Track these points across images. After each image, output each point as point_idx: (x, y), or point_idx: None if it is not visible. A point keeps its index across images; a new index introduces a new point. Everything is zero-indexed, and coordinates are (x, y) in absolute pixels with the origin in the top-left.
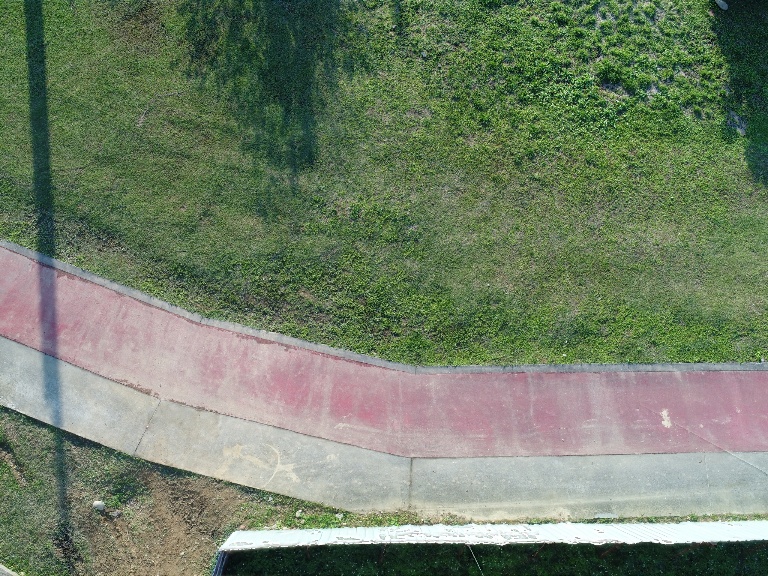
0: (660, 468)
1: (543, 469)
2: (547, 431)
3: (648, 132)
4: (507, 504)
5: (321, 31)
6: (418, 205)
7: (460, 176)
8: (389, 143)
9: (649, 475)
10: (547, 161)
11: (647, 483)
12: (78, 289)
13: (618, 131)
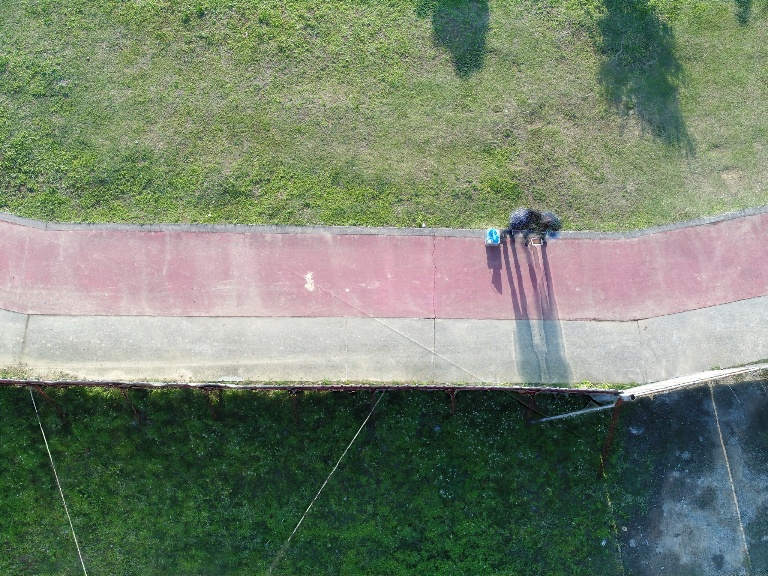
0: (296, 332)
1: (169, 329)
2: (179, 291)
3: None
4: (125, 364)
5: None
6: (72, 60)
7: (121, 32)
8: None
9: (283, 338)
10: (217, 19)
11: (280, 347)
12: None
13: None
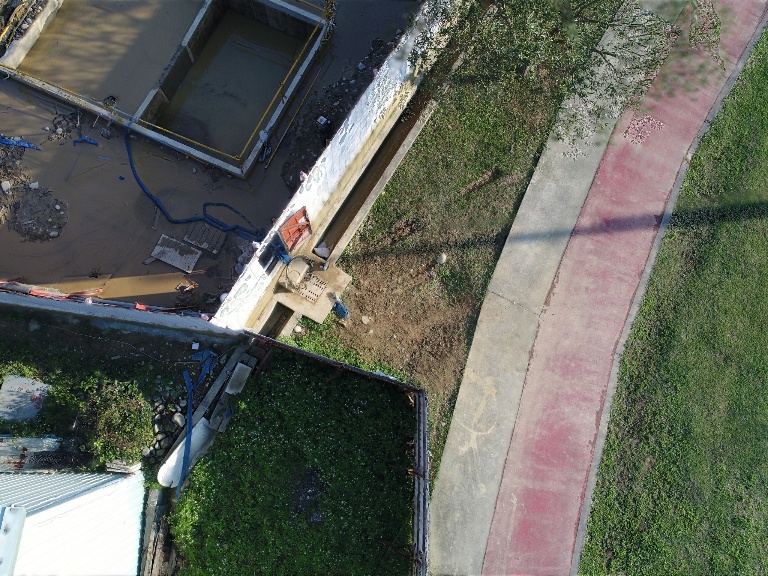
0: None
1: None
2: None
3: None
4: None
5: None
6: None
7: None
8: None
9: None
10: None
11: None
12: (644, 235)
13: None
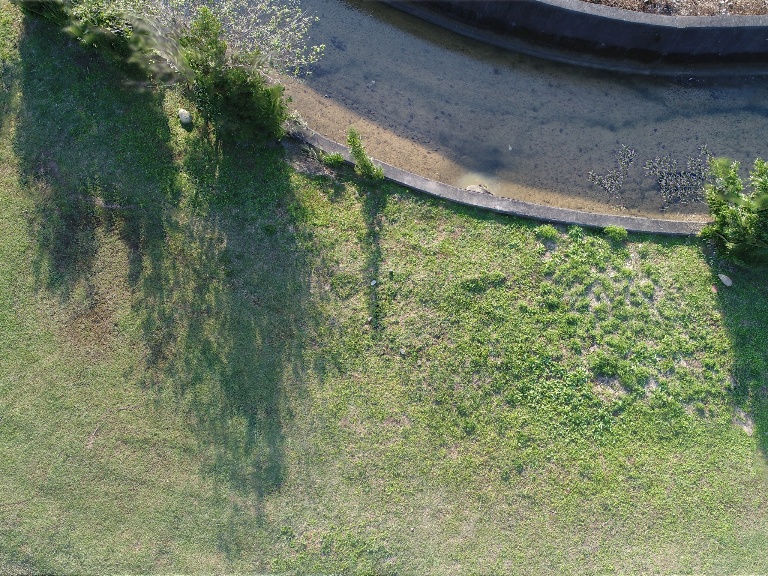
0: None
1: None
2: None
3: (647, 435)
4: None
5: (290, 327)
6: (396, 533)
7: (442, 496)
8: (364, 459)
9: None
10: (537, 474)
11: None
12: None
13: (614, 436)
